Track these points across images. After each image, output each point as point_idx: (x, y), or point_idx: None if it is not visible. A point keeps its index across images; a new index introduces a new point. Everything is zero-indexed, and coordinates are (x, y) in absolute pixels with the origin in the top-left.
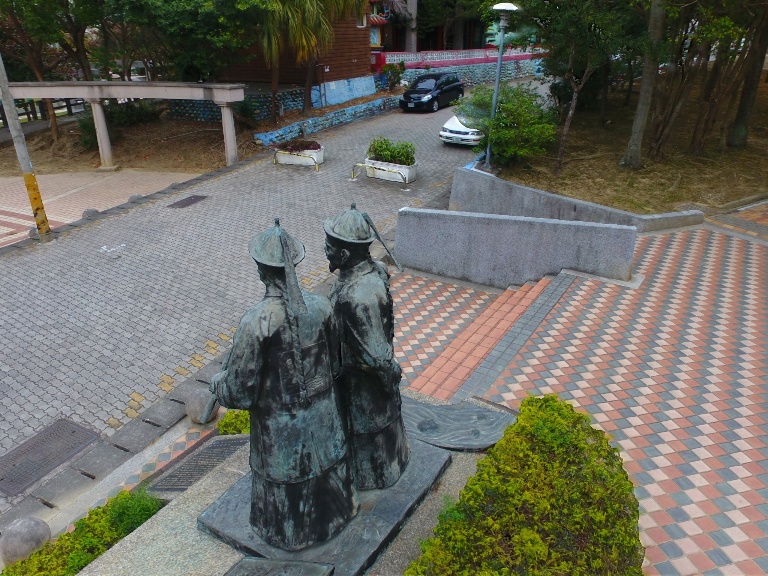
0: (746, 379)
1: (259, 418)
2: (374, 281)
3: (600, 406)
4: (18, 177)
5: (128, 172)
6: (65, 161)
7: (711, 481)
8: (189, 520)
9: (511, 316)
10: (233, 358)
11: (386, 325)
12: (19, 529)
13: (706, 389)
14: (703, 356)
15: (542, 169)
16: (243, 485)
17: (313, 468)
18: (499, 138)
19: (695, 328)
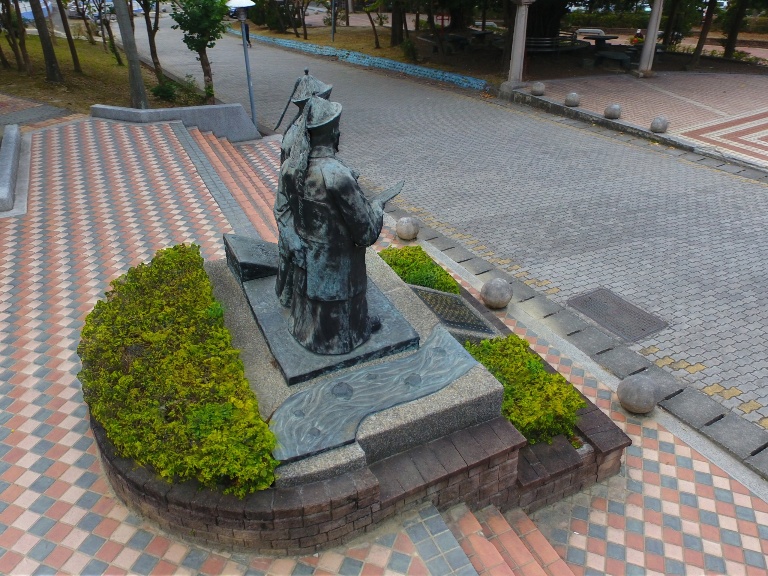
0: None
1: None
2: None
3: None
4: None
5: None
6: None
7: None
8: None
9: None
10: None
11: None
12: None
13: None
14: None
15: None
16: None
17: None
18: None
19: None
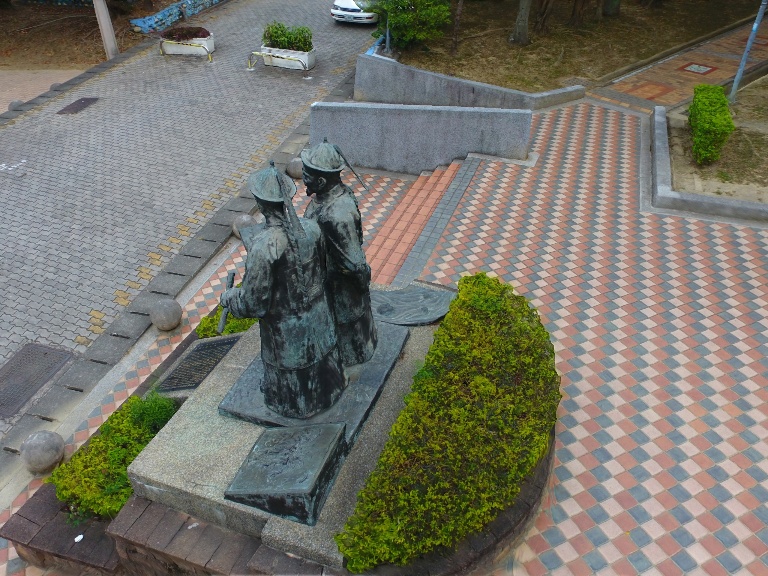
0: (623, 239)
1: (271, 323)
2: (347, 201)
3: (513, 274)
4: None
5: None
6: None
7: (600, 323)
8: (210, 409)
9: (430, 202)
10: (249, 279)
11: (358, 235)
12: (37, 442)
13: (593, 250)
14: (590, 223)
15: (439, 50)
16: (248, 376)
17: (317, 355)
18: (398, 23)
19: (582, 199)
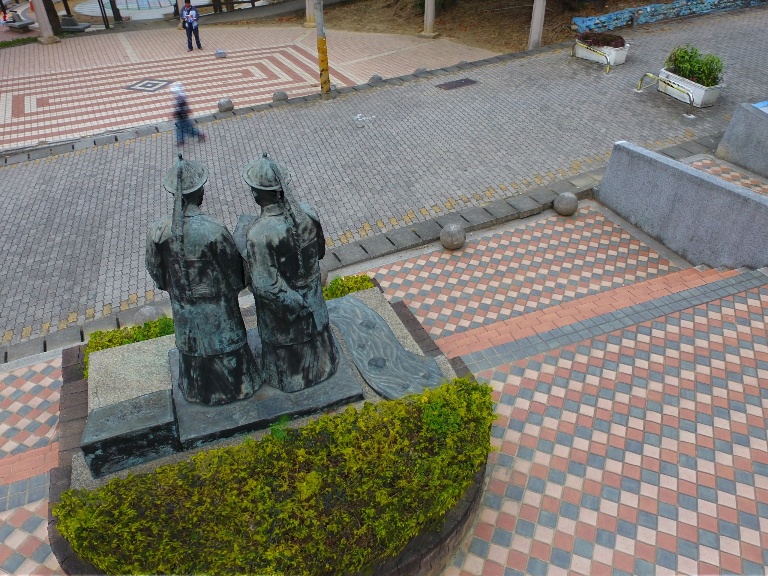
0: None
1: None
2: (273, 224)
3: (612, 426)
4: (357, 32)
5: (443, 41)
6: (400, 21)
7: (638, 553)
8: None
9: (642, 298)
10: None
11: (285, 263)
12: (145, 312)
13: None
14: None
15: None
16: None
17: (199, 350)
18: None
19: None
